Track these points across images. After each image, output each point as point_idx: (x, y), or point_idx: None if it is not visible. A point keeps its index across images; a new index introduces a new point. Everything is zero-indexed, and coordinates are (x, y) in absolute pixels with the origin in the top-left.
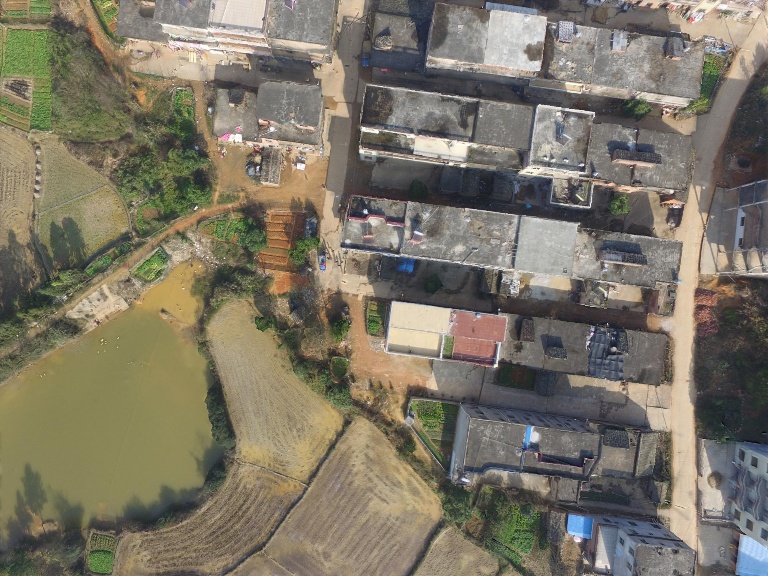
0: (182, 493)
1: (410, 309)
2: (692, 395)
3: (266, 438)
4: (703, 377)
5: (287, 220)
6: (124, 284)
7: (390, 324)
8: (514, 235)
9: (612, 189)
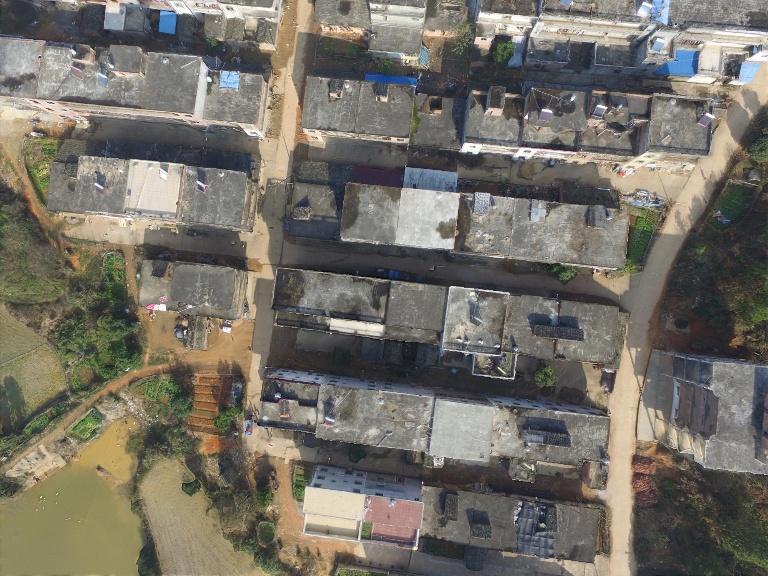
0: None
1: (324, 494)
2: (632, 568)
3: None
4: (643, 550)
5: (214, 382)
6: (60, 443)
7: (304, 510)
8: (429, 418)
9: None
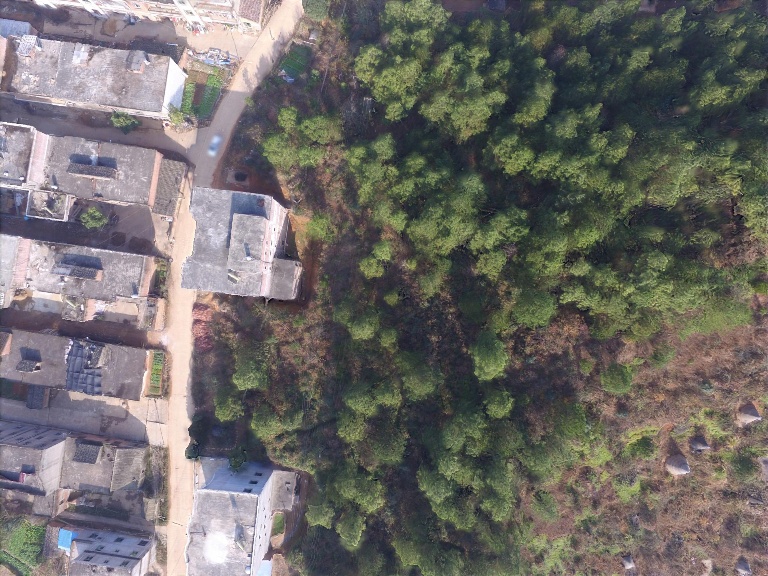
0: None
1: None
2: (190, 411)
3: None
4: (195, 393)
5: None
6: None
7: None
8: None
9: (105, 202)
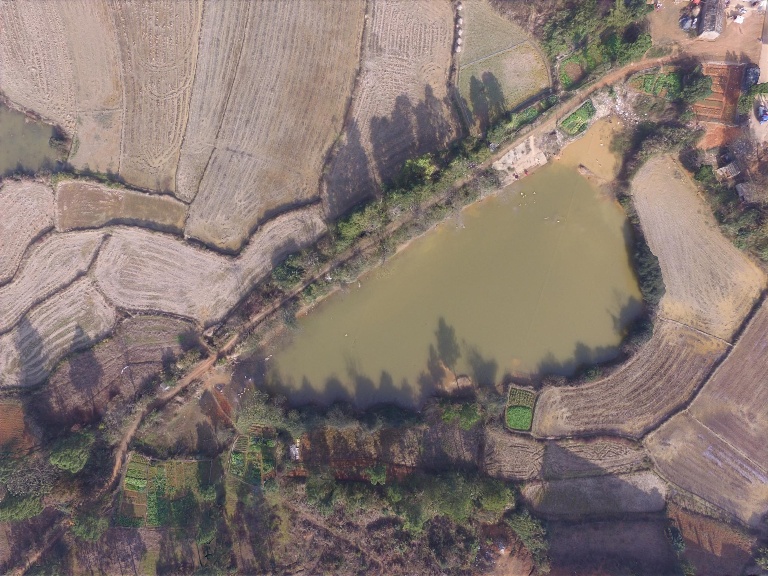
0: (598, 351)
1: None
2: None
3: (689, 295)
4: None
5: (722, 73)
6: (549, 137)
7: None
8: None
9: None
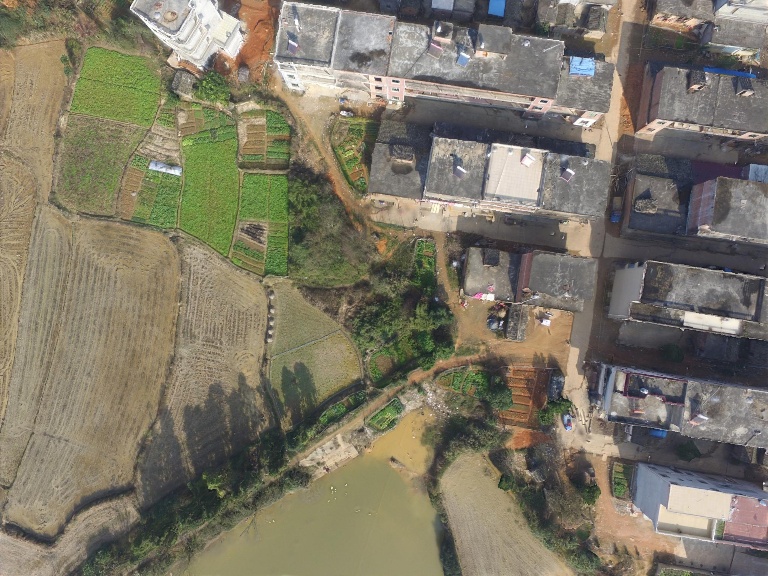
0: None
1: (689, 493)
2: None
3: None
4: None
5: (529, 376)
6: (357, 433)
7: (668, 508)
8: None
9: None
